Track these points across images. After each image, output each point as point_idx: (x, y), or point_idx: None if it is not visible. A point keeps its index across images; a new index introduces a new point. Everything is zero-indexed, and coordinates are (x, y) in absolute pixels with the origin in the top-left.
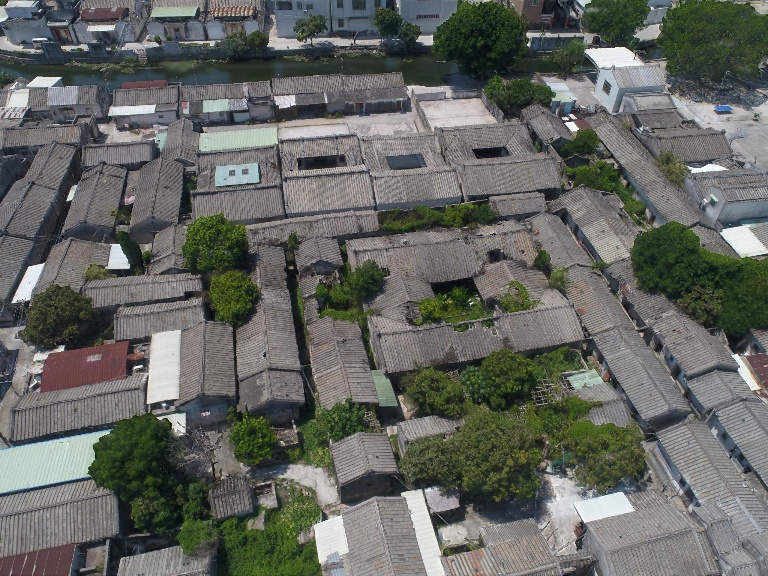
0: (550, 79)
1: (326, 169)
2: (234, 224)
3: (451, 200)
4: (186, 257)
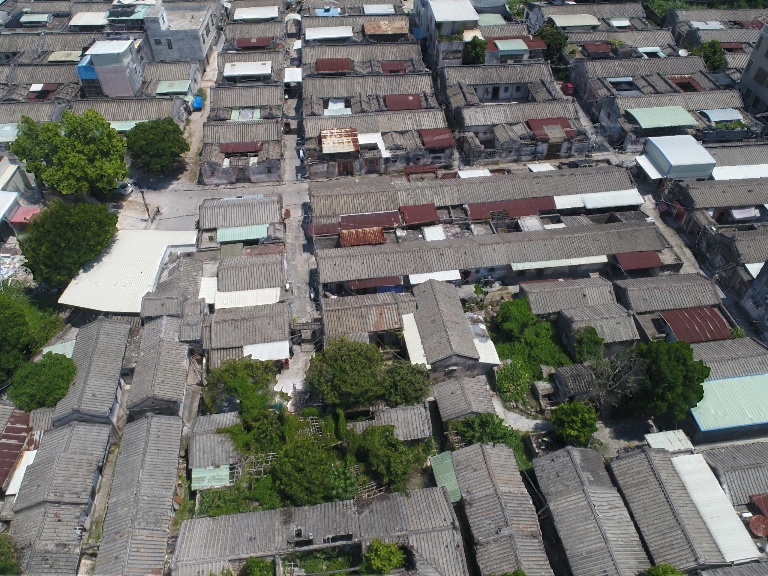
0: None
1: None
2: None
3: None
4: None
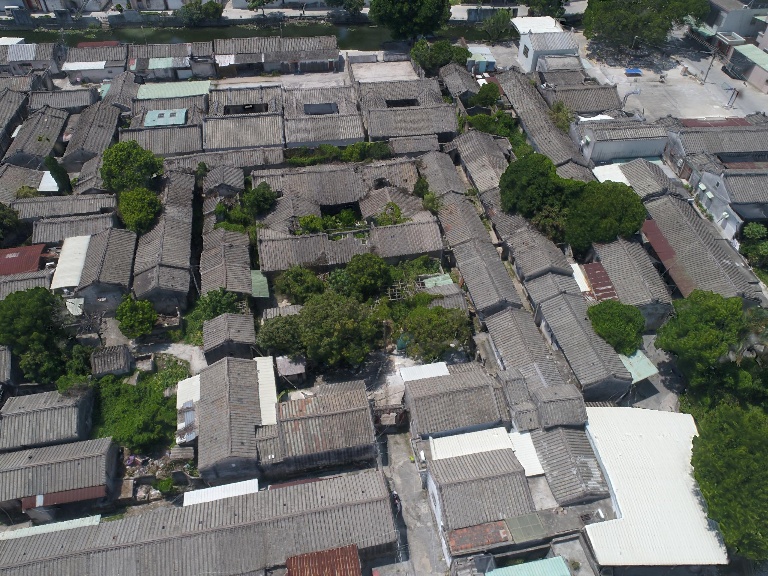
0: (479, 46)
1: (247, 114)
2: (157, 158)
3: (355, 141)
4: (103, 178)
